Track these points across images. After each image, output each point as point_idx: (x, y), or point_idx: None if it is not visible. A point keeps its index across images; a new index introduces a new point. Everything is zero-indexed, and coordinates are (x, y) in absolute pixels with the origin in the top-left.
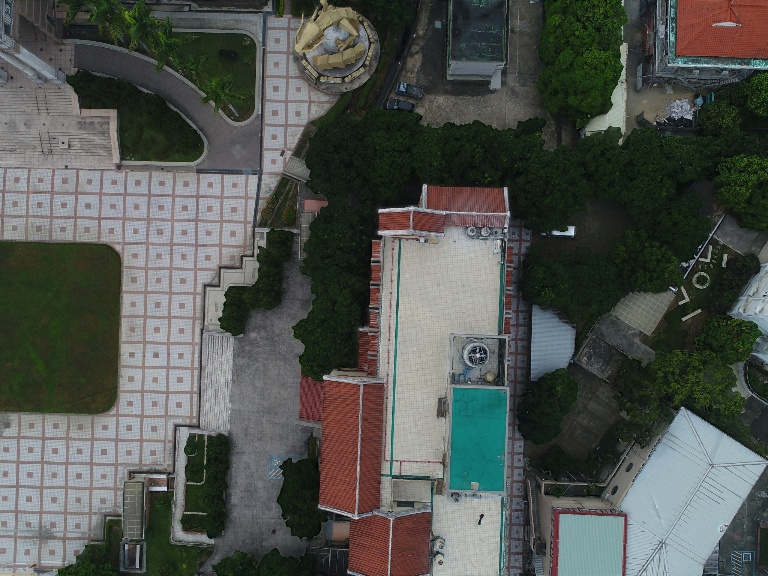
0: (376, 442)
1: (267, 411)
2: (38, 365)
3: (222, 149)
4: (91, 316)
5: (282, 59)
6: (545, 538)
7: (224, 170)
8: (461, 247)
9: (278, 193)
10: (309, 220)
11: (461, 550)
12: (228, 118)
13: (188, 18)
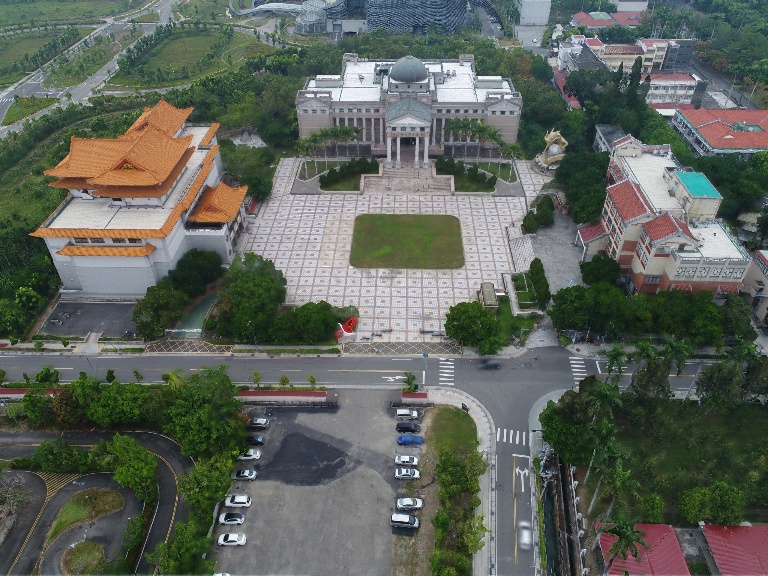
0: (645, 199)
1: (558, 262)
2: (417, 251)
3: (504, 190)
4: (445, 236)
5: (525, 169)
6: (759, 280)
7: (506, 196)
8: (652, 158)
9: (537, 200)
10: (562, 193)
11: (711, 244)
12: (505, 181)
13: (479, 160)
